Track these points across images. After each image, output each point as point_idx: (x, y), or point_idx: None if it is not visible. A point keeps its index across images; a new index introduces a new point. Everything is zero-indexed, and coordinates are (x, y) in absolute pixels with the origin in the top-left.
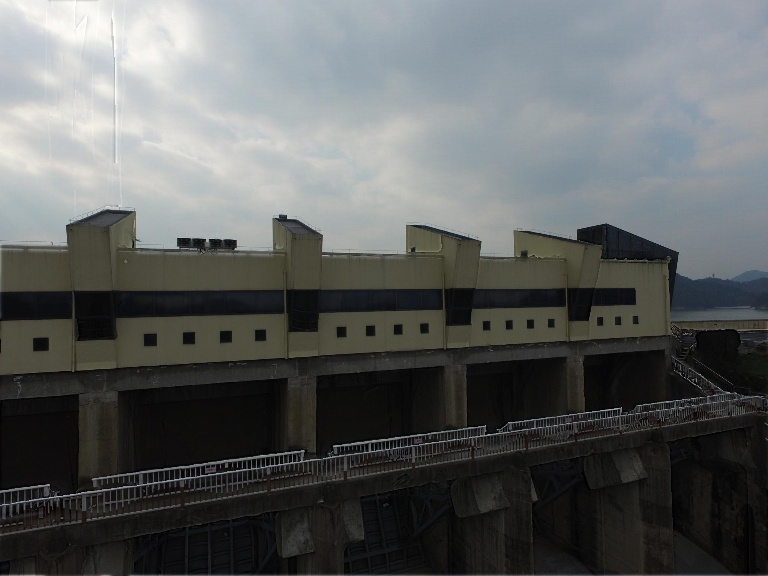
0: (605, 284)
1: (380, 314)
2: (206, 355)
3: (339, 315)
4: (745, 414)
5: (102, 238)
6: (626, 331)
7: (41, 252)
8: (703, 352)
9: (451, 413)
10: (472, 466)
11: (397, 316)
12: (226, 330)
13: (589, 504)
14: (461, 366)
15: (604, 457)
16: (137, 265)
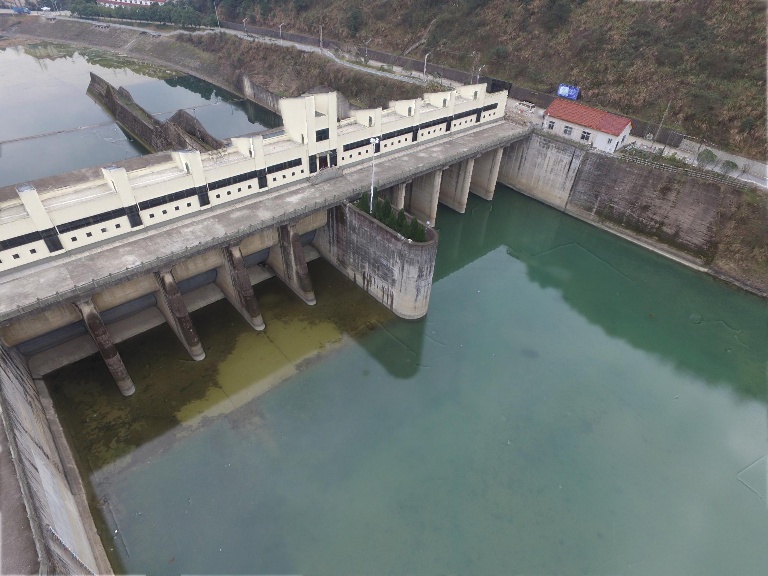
0: None
1: None
2: None
3: None
4: None
5: None
6: None
7: None
8: None
9: None
10: None
11: None
12: None
13: None
14: None
15: None
16: (233, 152)
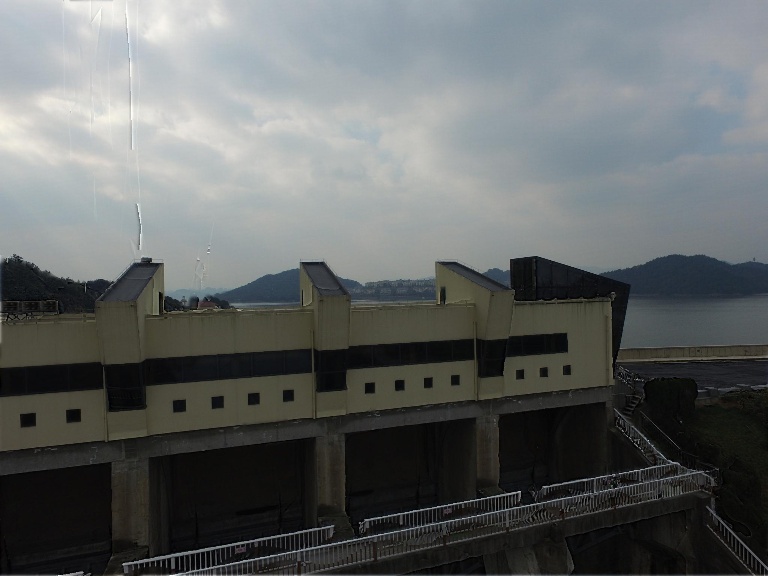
0: (527, 330)
1: (230, 382)
2: (3, 442)
3: (176, 387)
4: (682, 494)
5: None
6: (554, 383)
7: None
8: (651, 406)
9: (324, 491)
10: None
11: (252, 383)
12: (28, 412)
13: None
14: (338, 436)
15: None
16: None
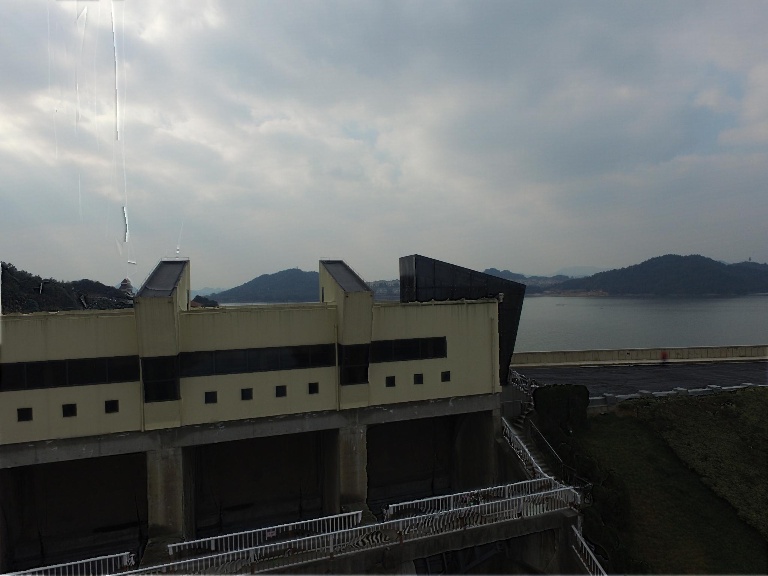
0: (399, 334)
1: (40, 392)
2: None
3: None
4: (547, 513)
5: None
6: (431, 391)
7: None
8: (538, 415)
9: (157, 509)
10: None
11: (68, 393)
12: None
13: None
14: (173, 449)
15: None
16: None
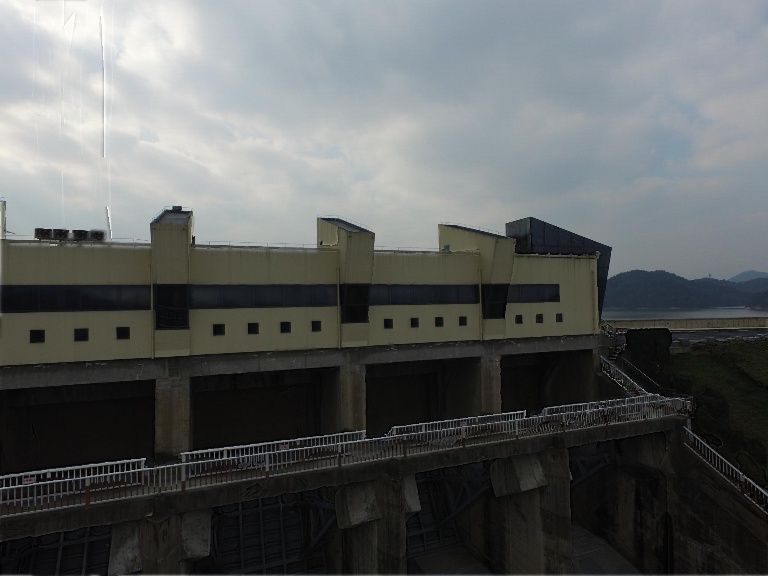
0: (525, 280)
1: (265, 311)
2: (58, 354)
3: (216, 312)
4: (663, 417)
5: None
6: (549, 329)
7: None
8: (632, 352)
9: (347, 416)
10: (338, 474)
11: (284, 313)
12: (82, 327)
13: (499, 512)
14: (359, 366)
15: (506, 463)
16: None
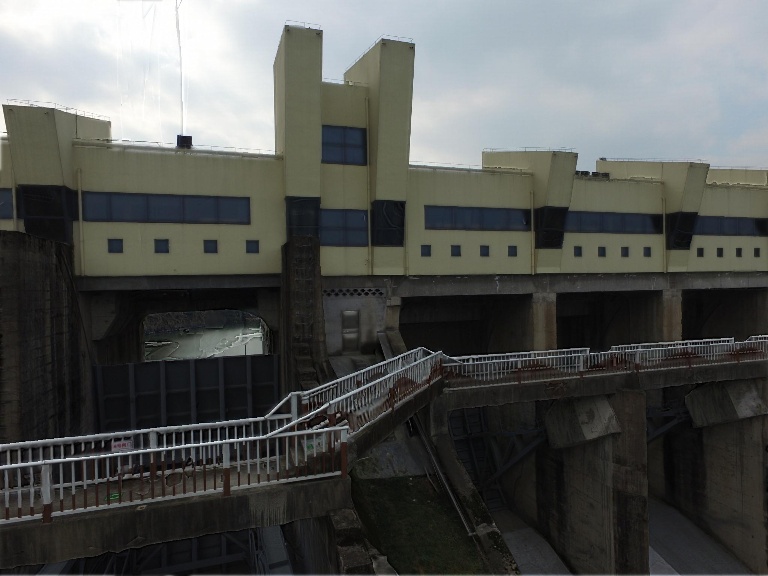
0: None
1: (726, 238)
2: (612, 267)
3: (698, 238)
4: None
5: (571, 162)
6: None
7: (510, 176)
8: None
9: None
10: None
11: (738, 241)
12: (625, 246)
13: None
14: None
15: None
16: None
